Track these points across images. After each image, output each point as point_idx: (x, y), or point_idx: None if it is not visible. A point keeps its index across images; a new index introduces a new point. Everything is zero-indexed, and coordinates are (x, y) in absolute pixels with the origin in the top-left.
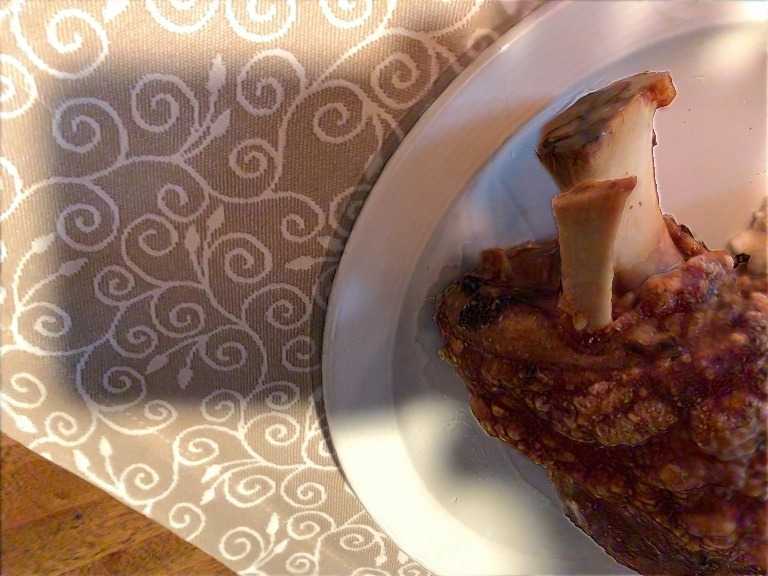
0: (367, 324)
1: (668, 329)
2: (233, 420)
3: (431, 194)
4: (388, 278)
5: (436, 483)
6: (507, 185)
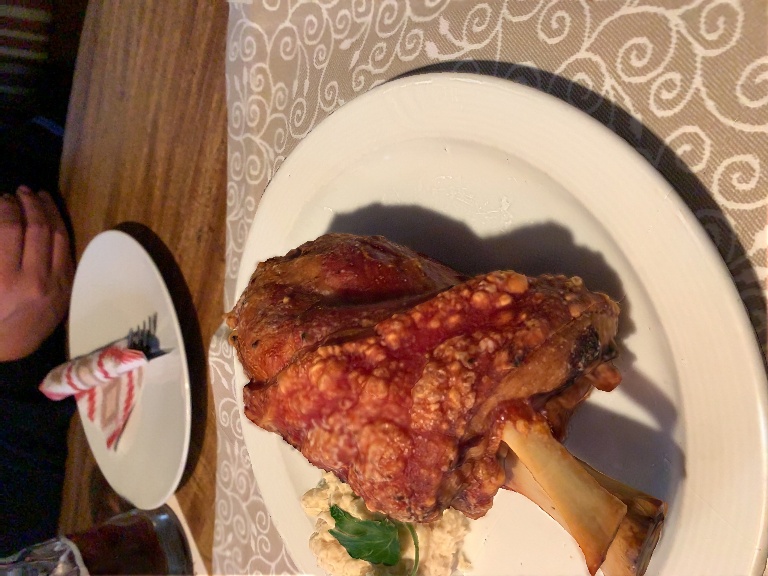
0: (659, 248)
1: (467, 463)
2: (694, 23)
3: (707, 397)
4: (678, 301)
5: (473, 151)
6: (647, 429)
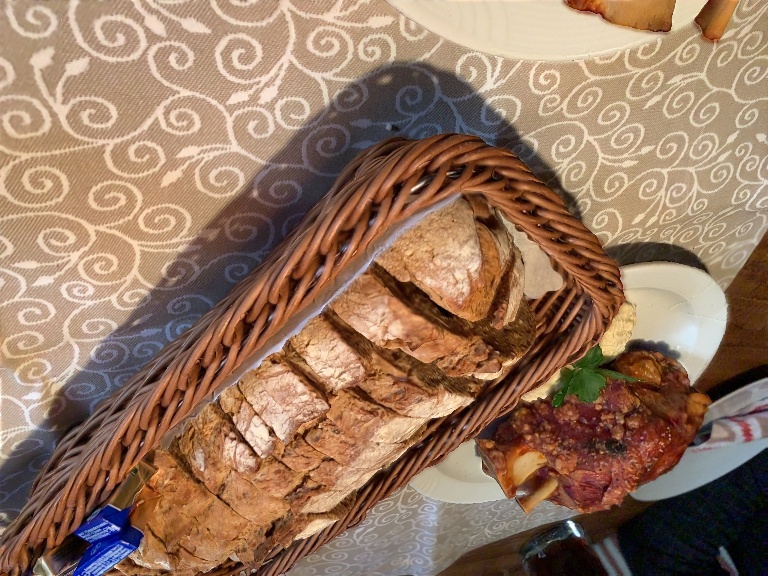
0: None
1: None
2: None
3: None
4: None
5: None
6: None
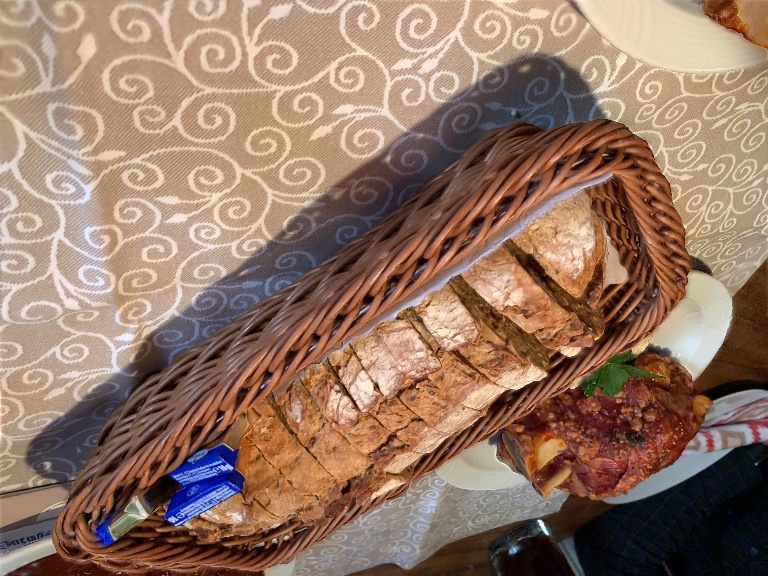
0: None
1: None
2: None
3: None
4: None
5: None
6: None
